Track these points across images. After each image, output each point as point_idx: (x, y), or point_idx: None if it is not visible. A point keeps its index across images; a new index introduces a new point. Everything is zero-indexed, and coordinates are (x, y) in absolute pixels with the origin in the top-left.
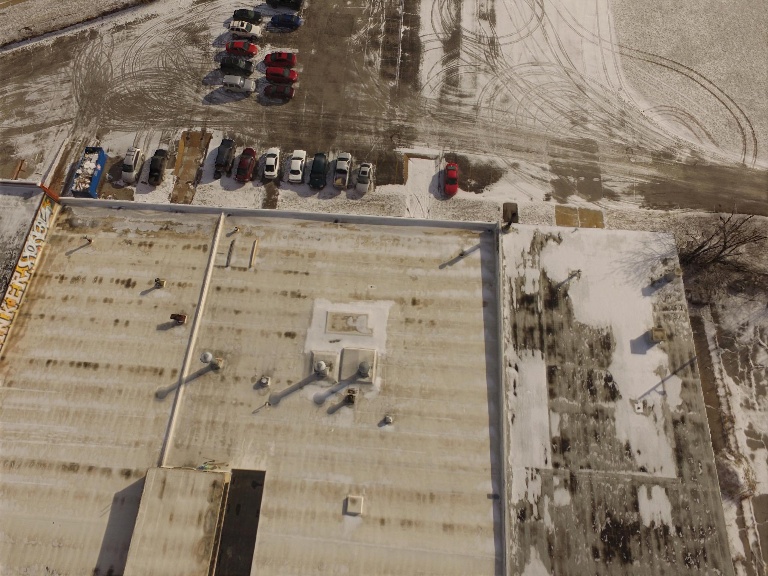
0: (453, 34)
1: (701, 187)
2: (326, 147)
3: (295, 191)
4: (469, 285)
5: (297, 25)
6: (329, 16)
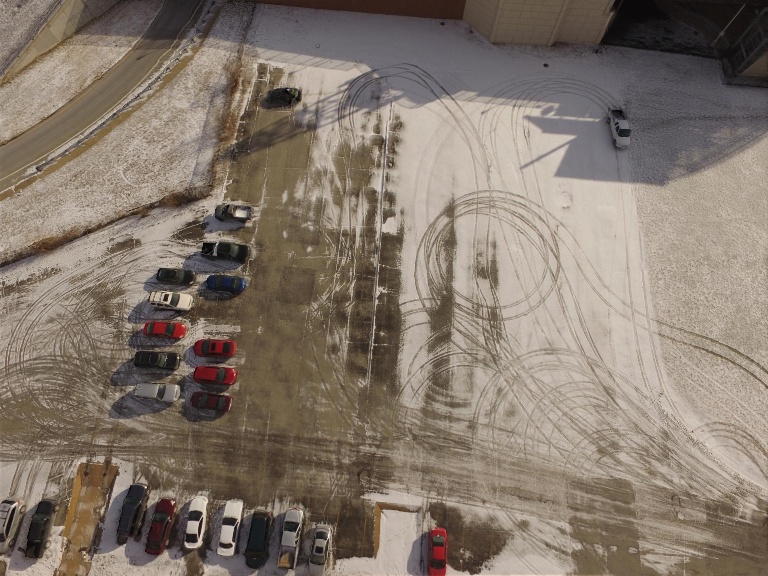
0: (443, 301)
1: None
2: (271, 492)
3: (226, 568)
4: None
5: (240, 291)
6: (283, 271)
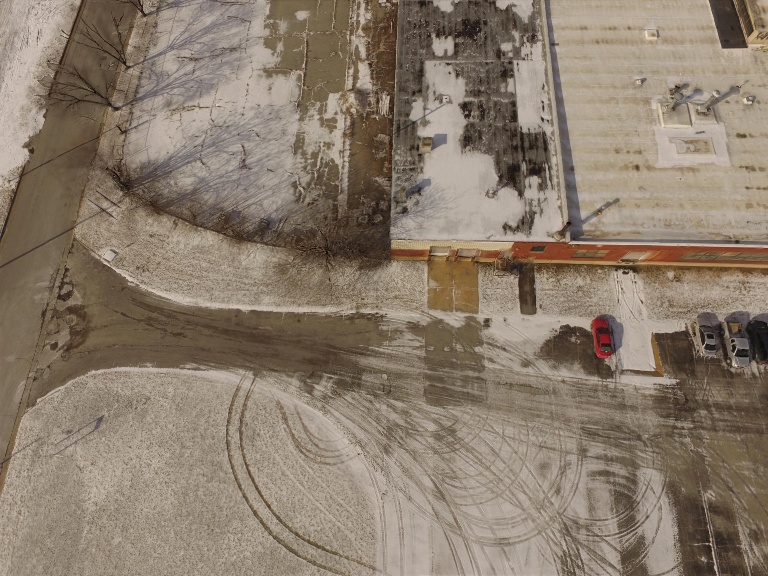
0: None
1: (314, 343)
2: (766, 381)
3: None
4: (588, 185)
5: None
6: None
